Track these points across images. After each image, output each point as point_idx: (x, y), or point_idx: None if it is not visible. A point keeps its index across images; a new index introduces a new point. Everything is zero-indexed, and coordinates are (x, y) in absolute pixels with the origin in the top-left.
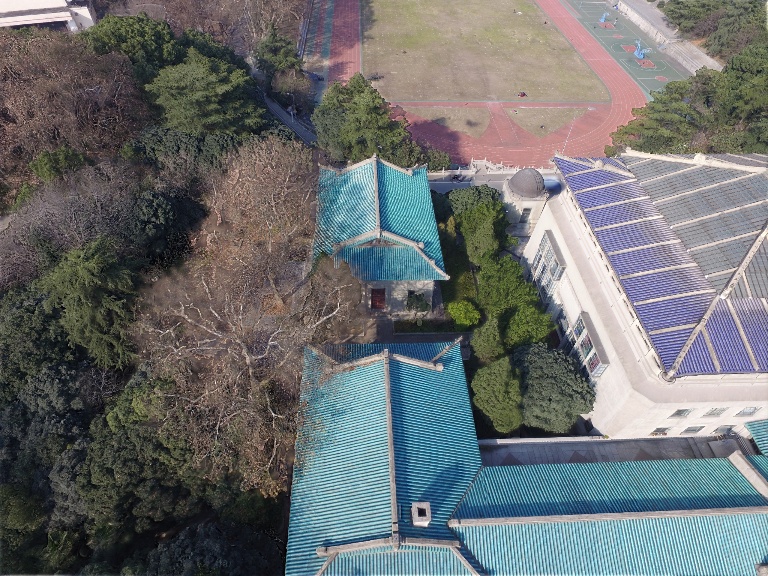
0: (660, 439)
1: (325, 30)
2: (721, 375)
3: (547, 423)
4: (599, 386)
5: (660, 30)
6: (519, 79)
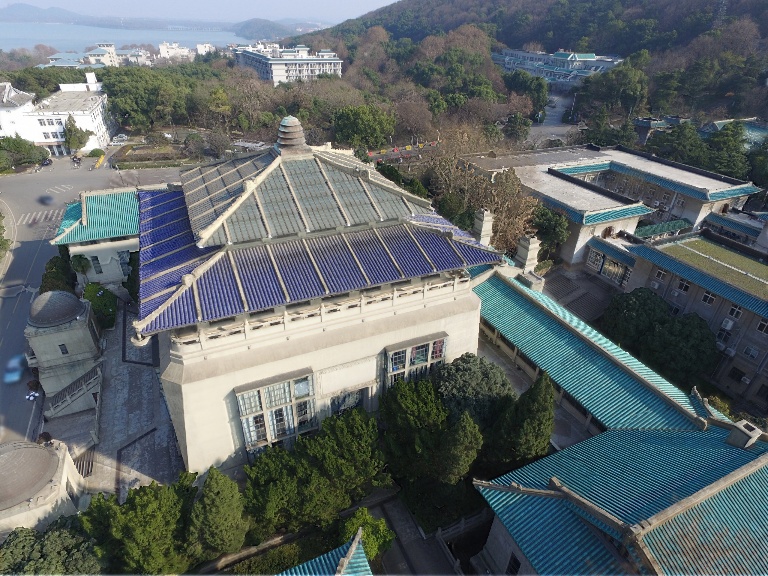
0: None
1: None
2: None
3: None
4: (446, 356)
5: None
6: None
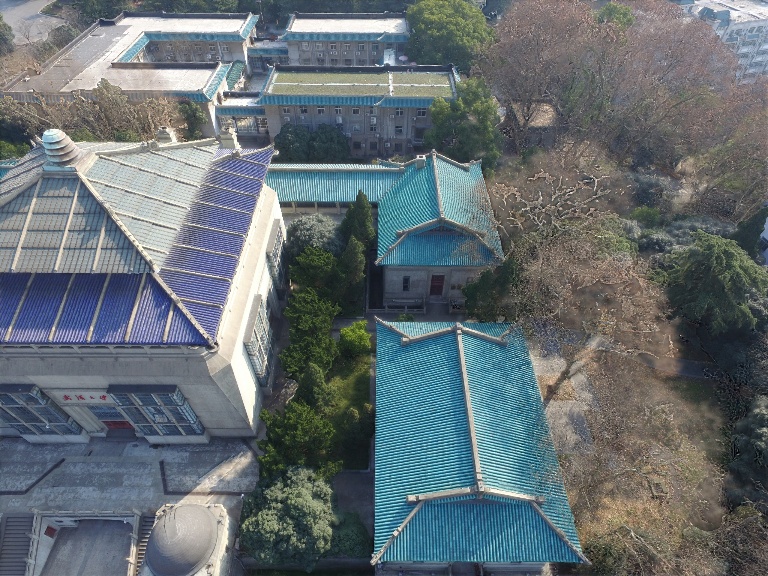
0: None
1: None
2: None
3: None
4: None
5: None
6: None
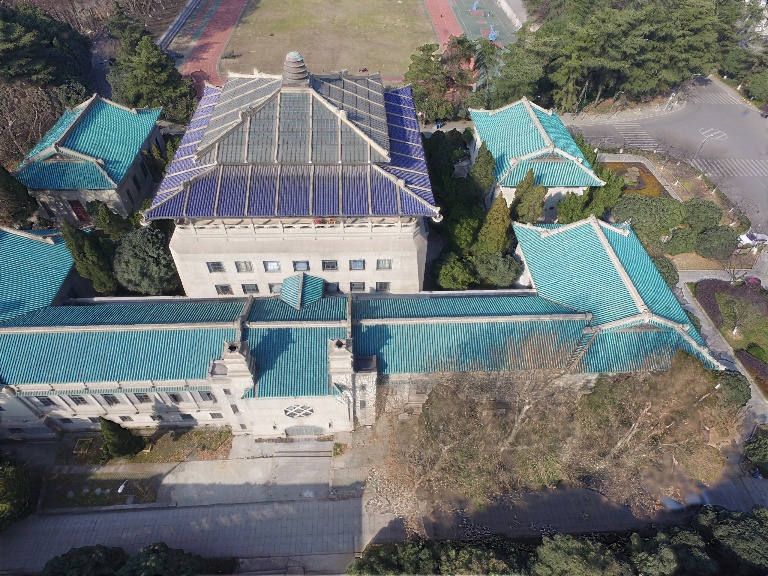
0: (233, 299)
1: (206, 16)
2: (223, 230)
3: (132, 283)
4: None
5: (518, 16)
6: (368, 57)
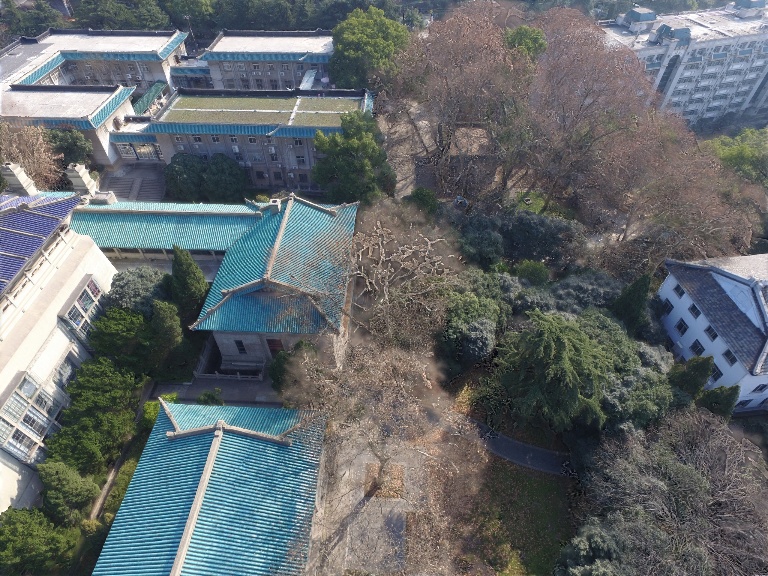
0: None
1: None
2: None
3: None
4: None
5: None
6: None
